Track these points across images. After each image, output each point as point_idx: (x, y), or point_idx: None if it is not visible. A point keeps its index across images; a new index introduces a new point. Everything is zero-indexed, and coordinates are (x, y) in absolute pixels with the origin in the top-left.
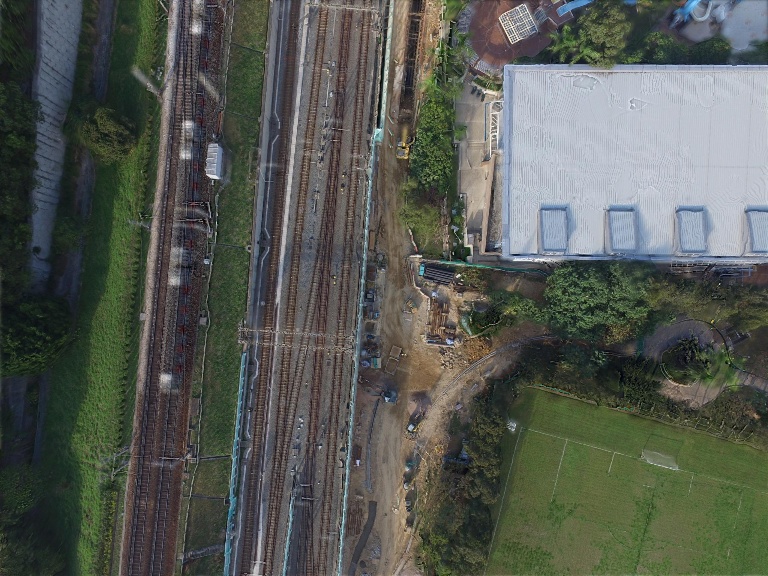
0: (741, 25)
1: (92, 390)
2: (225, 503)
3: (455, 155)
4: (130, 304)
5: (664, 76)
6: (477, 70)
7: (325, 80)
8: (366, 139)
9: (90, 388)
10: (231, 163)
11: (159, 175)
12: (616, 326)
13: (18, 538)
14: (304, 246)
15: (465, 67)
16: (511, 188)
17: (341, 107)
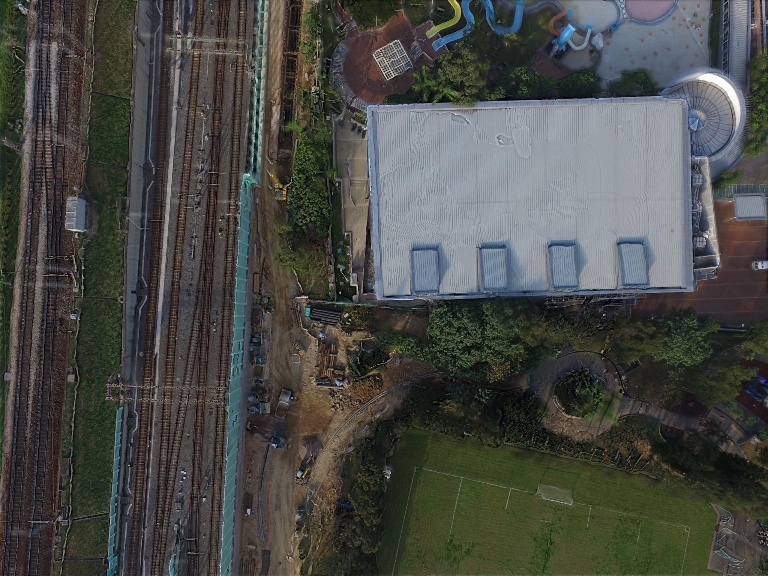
0: (622, 52)
1: None
2: (104, 563)
3: (338, 193)
4: None
5: (528, 112)
6: (354, 108)
7: (200, 123)
8: None
9: None
10: (98, 214)
11: (20, 230)
12: (495, 364)
13: None
14: (182, 293)
15: (343, 104)
16: (381, 229)
17: (217, 150)
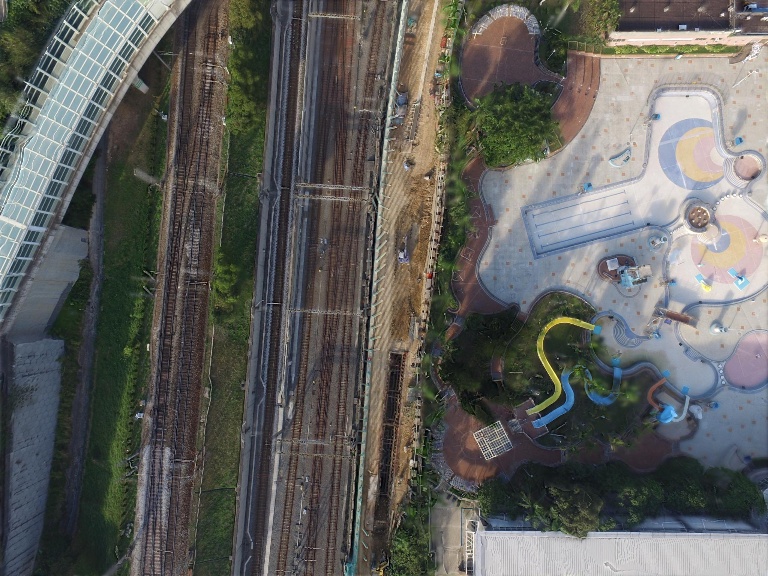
0: (719, 419)
1: None
2: None
3: (431, 562)
4: None
5: (638, 546)
6: (452, 485)
7: (298, 496)
8: (340, 558)
9: None
10: None
11: None
12: None
13: None
14: None
15: (440, 477)
16: None
17: (315, 525)
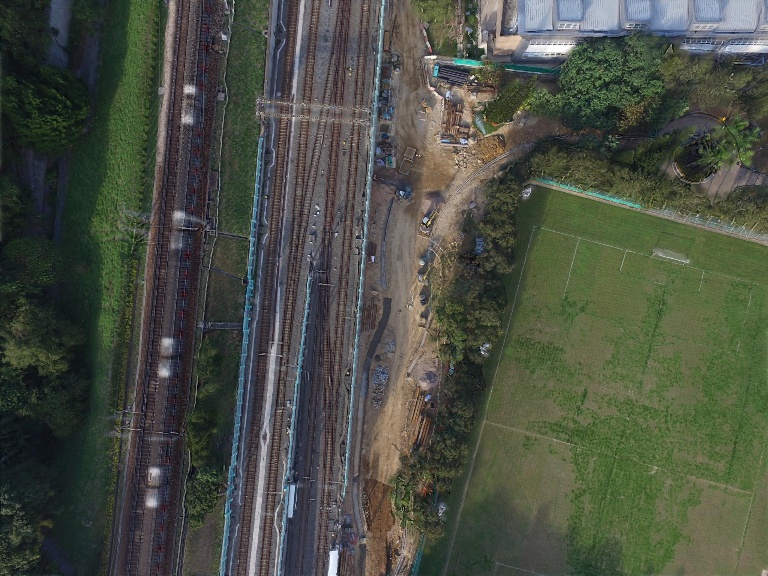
0: None
1: (111, 172)
2: (243, 283)
3: None
4: (149, 77)
5: None
6: None
7: None
8: None
9: (109, 170)
10: None
11: None
12: (630, 104)
13: (40, 305)
14: (320, 39)
15: None
16: None
17: None
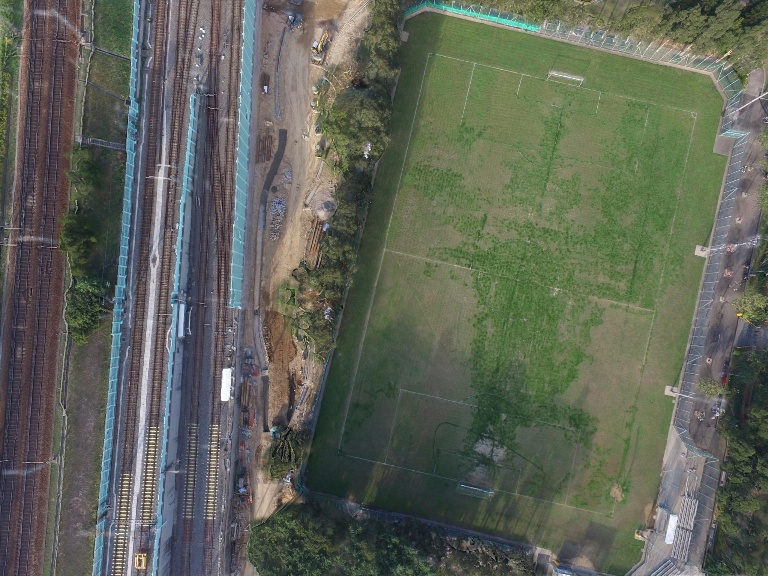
0: None
1: None
2: (126, 103)
3: None
4: None
5: None
6: None
7: None
8: None
9: None
10: None
11: None
12: None
13: None
14: None
15: None
16: None
17: None
